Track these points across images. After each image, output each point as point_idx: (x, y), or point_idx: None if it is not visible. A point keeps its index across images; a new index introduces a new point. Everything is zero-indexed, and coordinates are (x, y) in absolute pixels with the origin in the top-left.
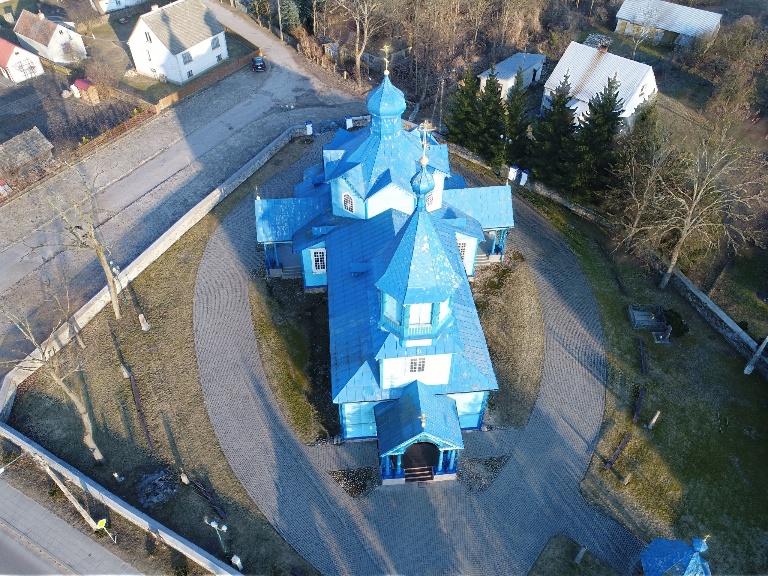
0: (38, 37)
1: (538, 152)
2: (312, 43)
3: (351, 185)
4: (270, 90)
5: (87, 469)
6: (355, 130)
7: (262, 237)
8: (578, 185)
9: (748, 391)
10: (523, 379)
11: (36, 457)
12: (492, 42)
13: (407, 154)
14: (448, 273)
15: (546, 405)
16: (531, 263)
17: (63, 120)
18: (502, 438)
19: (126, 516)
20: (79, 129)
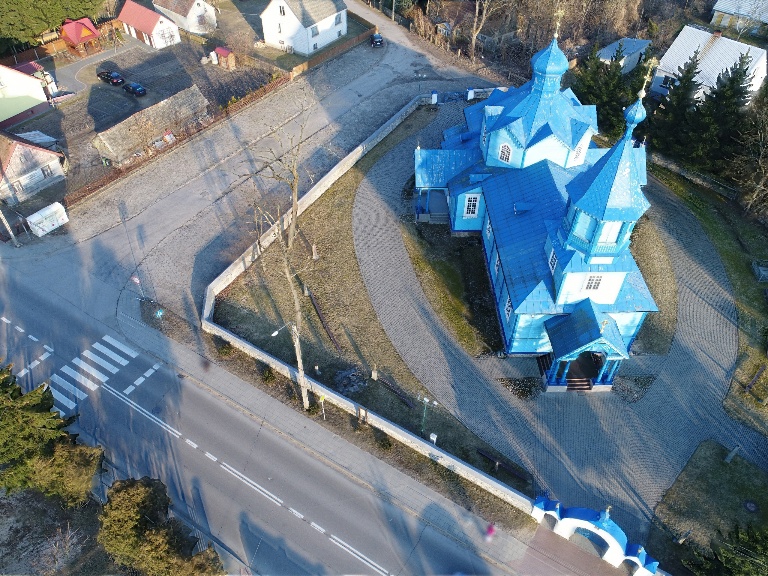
0: (177, 9)
1: (659, 124)
2: (427, 23)
3: (514, 136)
4: (390, 64)
5: None
6: (476, 101)
7: (420, 183)
8: (699, 154)
9: None
10: (661, 316)
11: (294, 328)
12: (599, 27)
13: (563, 111)
14: (639, 198)
15: (684, 338)
16: (656, 222)
17: (206, 83)
18: (648, 362)
19: (331, 399)
20: (222, 91)
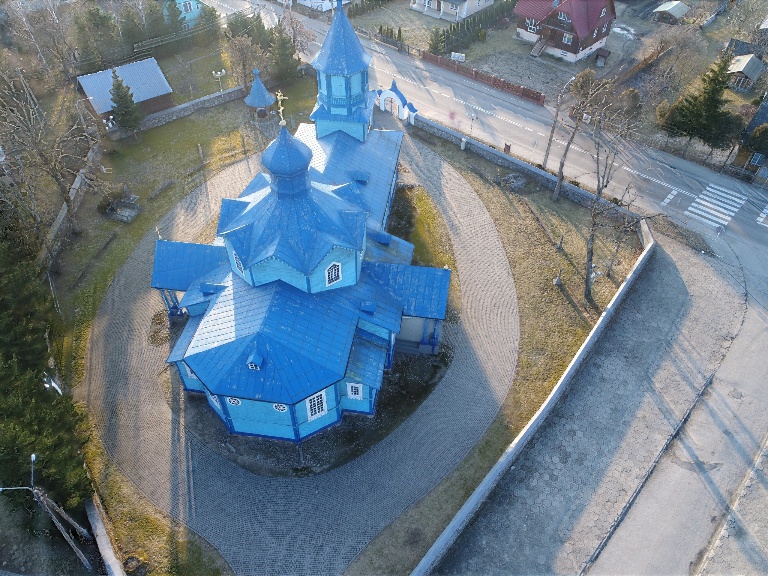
0: None
1: None
2: None
3: None
4: None
5: (563, 198)
6: None
7: None
8: None
9: (118, 165)
10: None
11: None
12: None
13: None
14: None
15: None
16: None
17: None
18: None
19: None
20: None
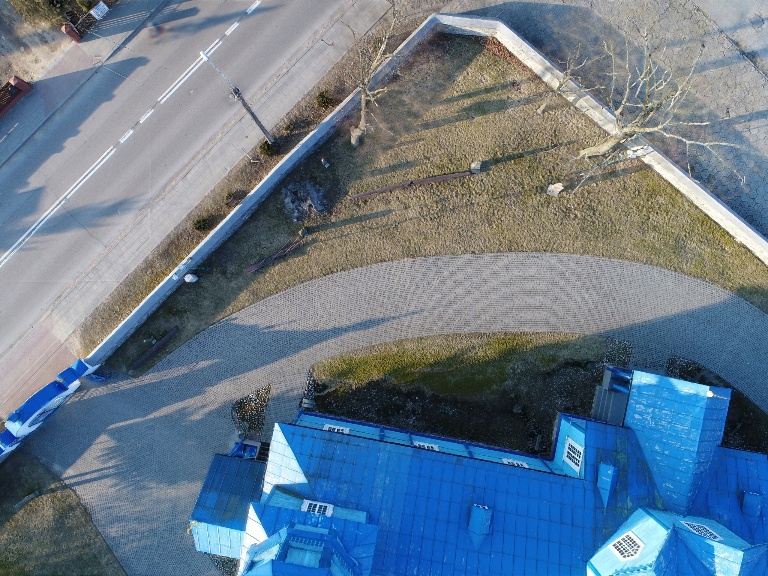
0: None
1: None
2: None
3: (630, 573)
4: None
5: None
6: None
7: (641, 379)
8: None
9: None
10: None
11: None
12: None
13: None
14: None
15: None
16: None
17: None
18: None
19: None
20: None
